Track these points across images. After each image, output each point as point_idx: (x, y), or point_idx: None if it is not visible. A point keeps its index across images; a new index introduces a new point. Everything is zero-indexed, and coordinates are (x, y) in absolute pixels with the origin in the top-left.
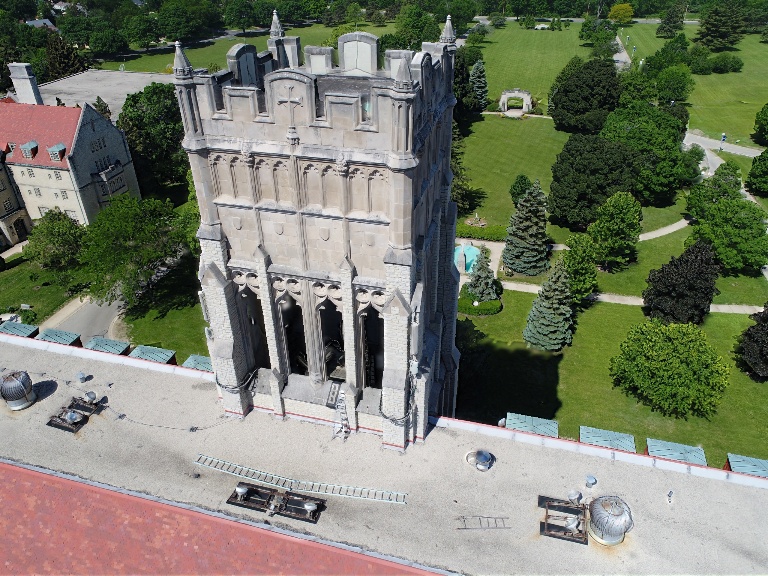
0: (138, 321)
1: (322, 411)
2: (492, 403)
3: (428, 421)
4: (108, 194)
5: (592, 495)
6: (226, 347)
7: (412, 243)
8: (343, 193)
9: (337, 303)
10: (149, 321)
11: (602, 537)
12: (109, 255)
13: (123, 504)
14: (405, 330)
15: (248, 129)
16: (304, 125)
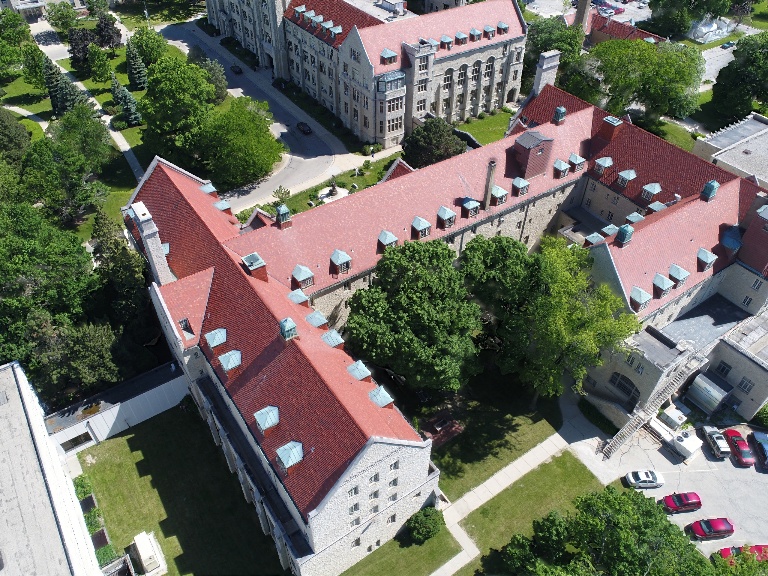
0: None
1: None
2: None
3: None
4: None
5: None
6: None
7: None
8: None
9: None
10: None
11: None
12: None
13: None
14: None
15: None
16: None
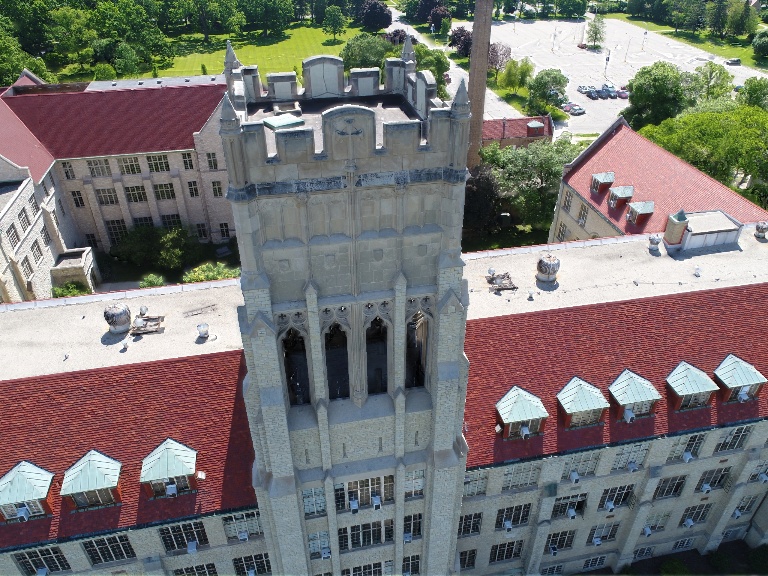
0: None
1: None
2: None
3: None
4: None
5: None
6: None
7: None
8: None
9: None
10: None
11: None
12: None
13: None
14: None
15: None
16: None
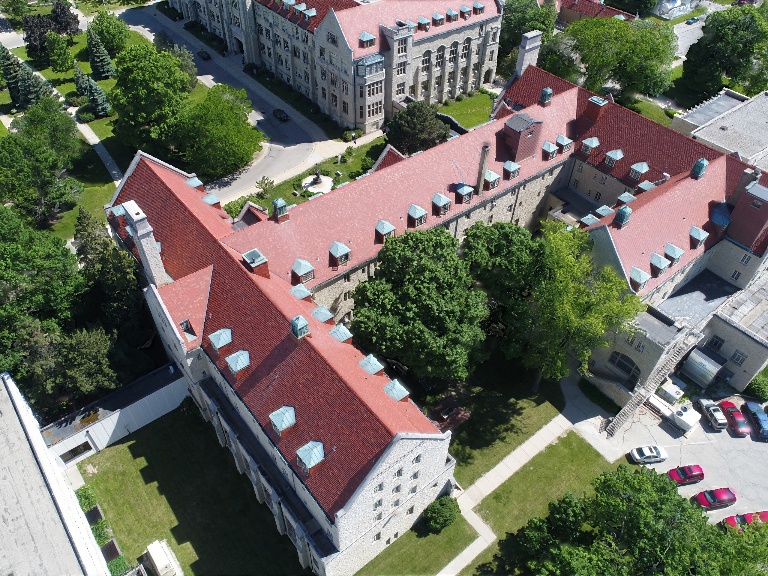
0: None
1: None
2: None
3: None
4: None
5: None
6: None
7: None
8: None
9: None
10: None
11: None
12: None
13: None
14: None
15: None
16: None
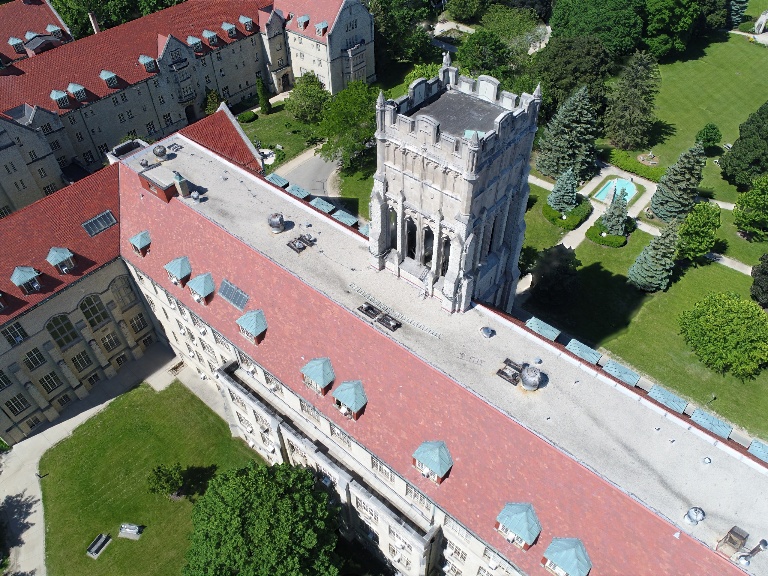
0: (348, 178)
1: (417, 281)
2: (574, 314)
3: (471, 304)
4: (350, 67)
5: (535, 367)
6: (377, 234)
7: (471, 213)
8: (442, 180)
9: (433, 230)
10: (355, 180)
11: (523, 385)
12: (339, 127)
13: (313, 294)
14: (459, 254)
15: (405, 137)
16: (430, 144)
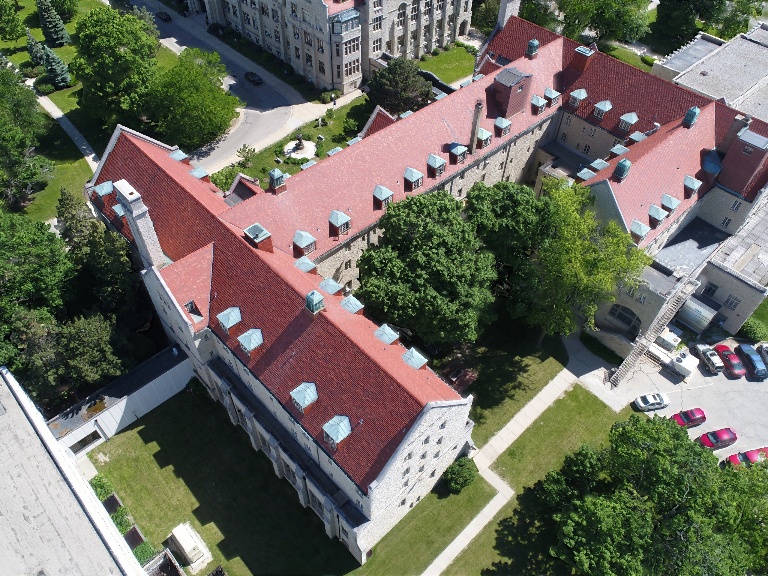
0: None
1: None
2: None
3: None
4: None
5: None
6: None
7: None
8: None
9: None
10: None
11: None
12: None
13: None
14: None
15: None
16: None
